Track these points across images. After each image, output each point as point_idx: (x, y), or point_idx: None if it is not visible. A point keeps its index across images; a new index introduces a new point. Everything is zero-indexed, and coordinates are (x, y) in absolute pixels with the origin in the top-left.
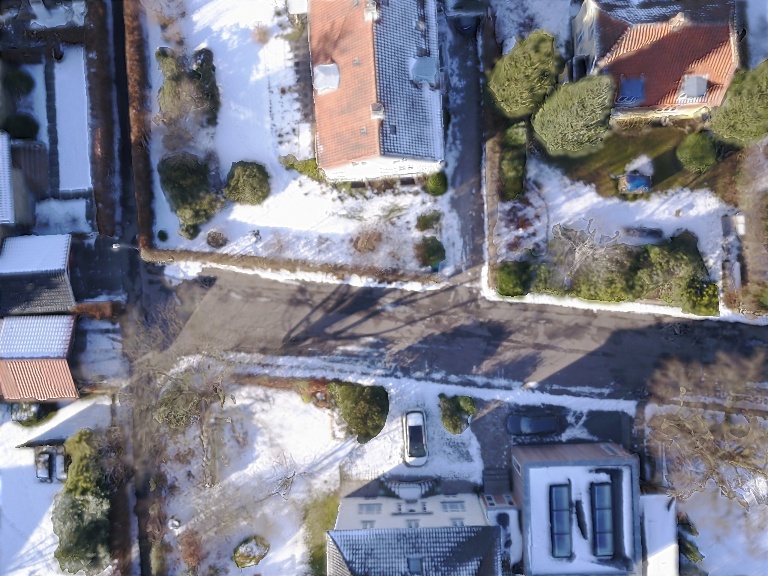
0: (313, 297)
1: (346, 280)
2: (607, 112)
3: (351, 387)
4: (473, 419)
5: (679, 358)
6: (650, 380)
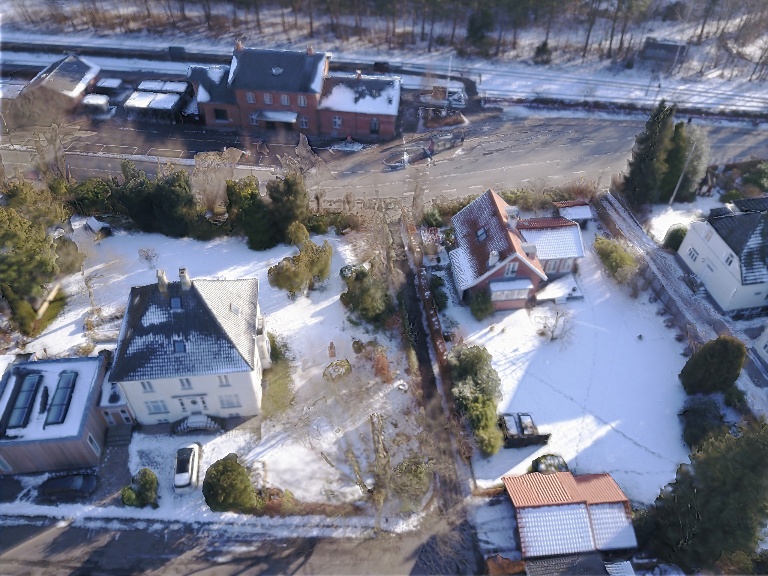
0: None
1: None
2: None
3: (240, 505)
4: None
5: None
6: None
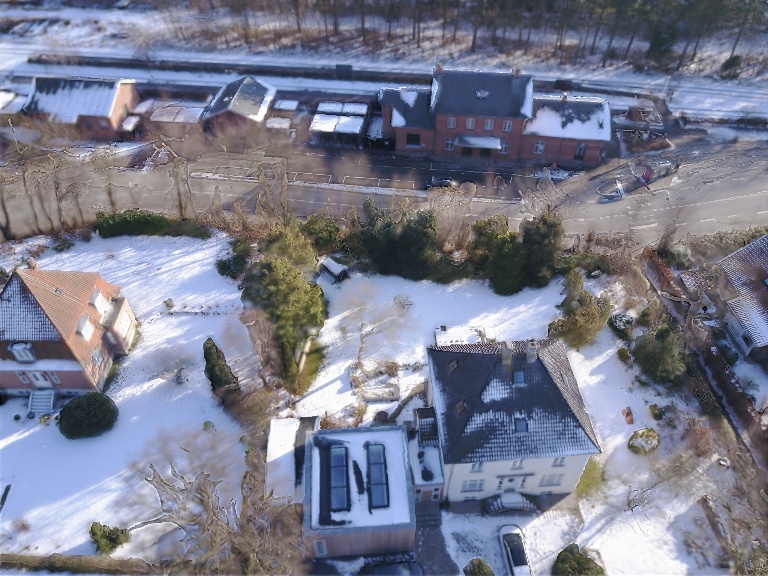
0: None
1: None
2: None
3: None
4: None
5: None
6: None
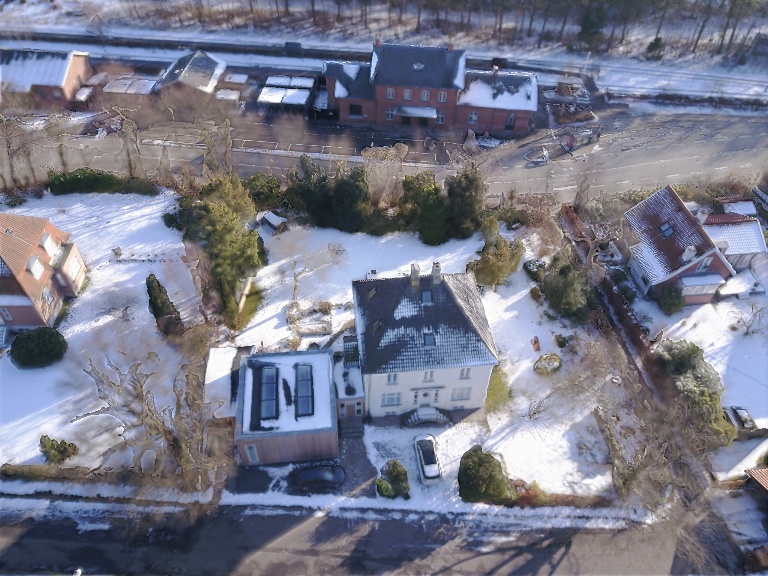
0: None
1: None
2: None
3: (496, 496)
4: (375, 479)
5: (171, 550)
6: (204, 526)
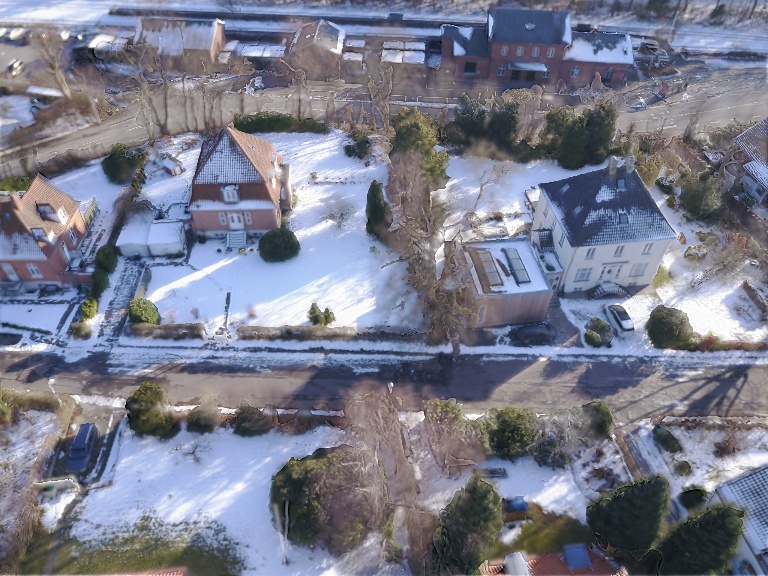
0: (743, 406)
1: (724, 420)
2: (610, 509)
3: (685, 340)
4: (579, 335)
5: (434, 384)
6: (453, 368)
